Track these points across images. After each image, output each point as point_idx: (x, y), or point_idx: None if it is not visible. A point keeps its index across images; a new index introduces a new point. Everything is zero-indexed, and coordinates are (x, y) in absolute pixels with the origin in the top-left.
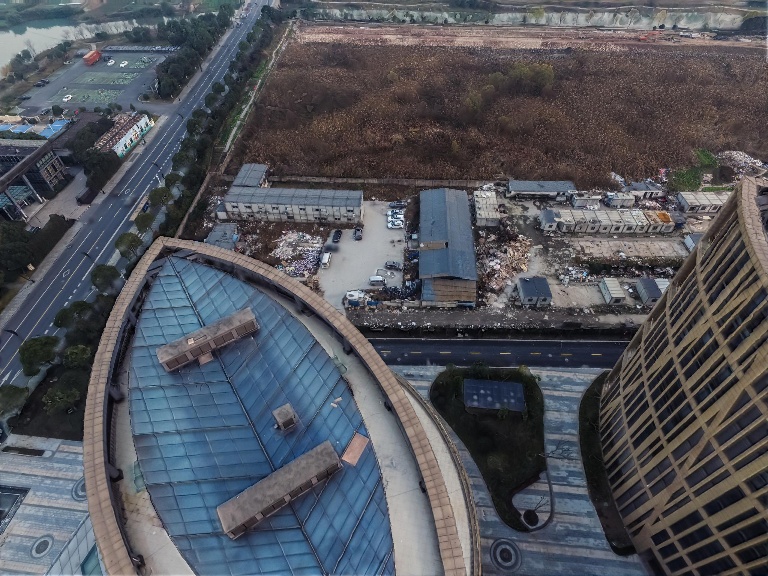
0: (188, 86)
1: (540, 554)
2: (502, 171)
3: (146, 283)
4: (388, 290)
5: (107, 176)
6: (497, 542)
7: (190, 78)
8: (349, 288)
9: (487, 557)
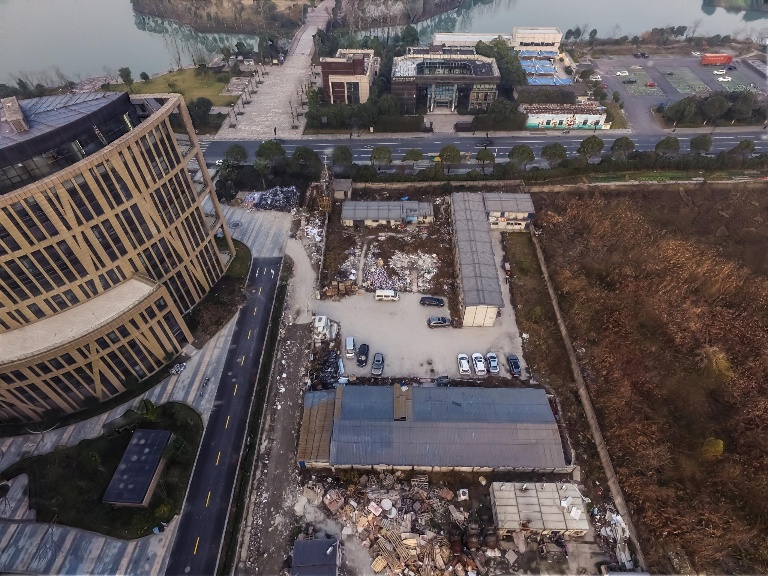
0: (715, 129)
1: None
2: (711, 575)
3: (143, 105)
4: (329, 356)
5: (495, 127)
6: (1, 455)
7: (736, 125)
8: (344, 323)
9: None
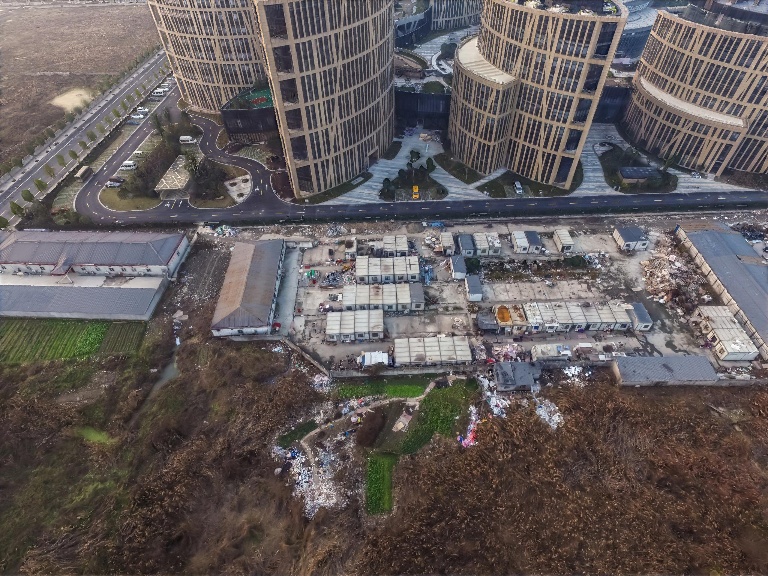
0: None
1: (596, 138)
2: (741, 434)
3: None
4: (759, 231)
5: None
6: None
7: None
8: None
9: (618, 136)
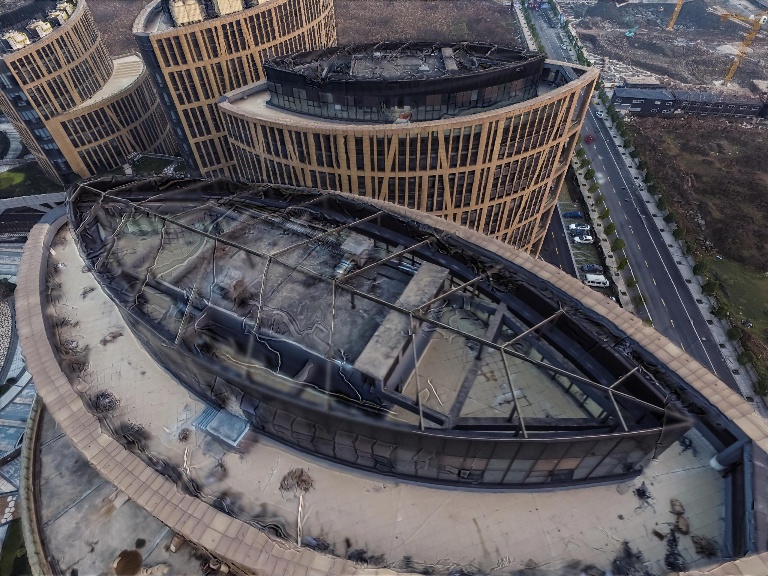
0: None
1: None
2: None
3: None
4: None
5: None
6: None
7: None
8: None
9: None
